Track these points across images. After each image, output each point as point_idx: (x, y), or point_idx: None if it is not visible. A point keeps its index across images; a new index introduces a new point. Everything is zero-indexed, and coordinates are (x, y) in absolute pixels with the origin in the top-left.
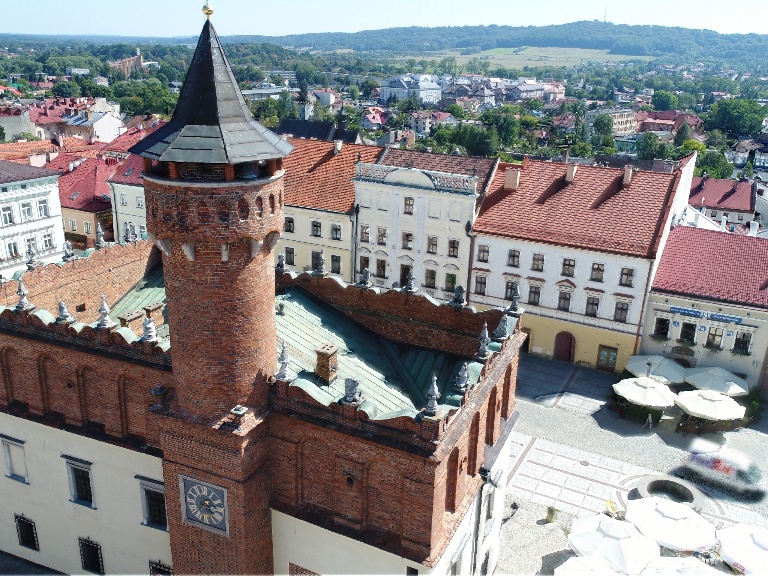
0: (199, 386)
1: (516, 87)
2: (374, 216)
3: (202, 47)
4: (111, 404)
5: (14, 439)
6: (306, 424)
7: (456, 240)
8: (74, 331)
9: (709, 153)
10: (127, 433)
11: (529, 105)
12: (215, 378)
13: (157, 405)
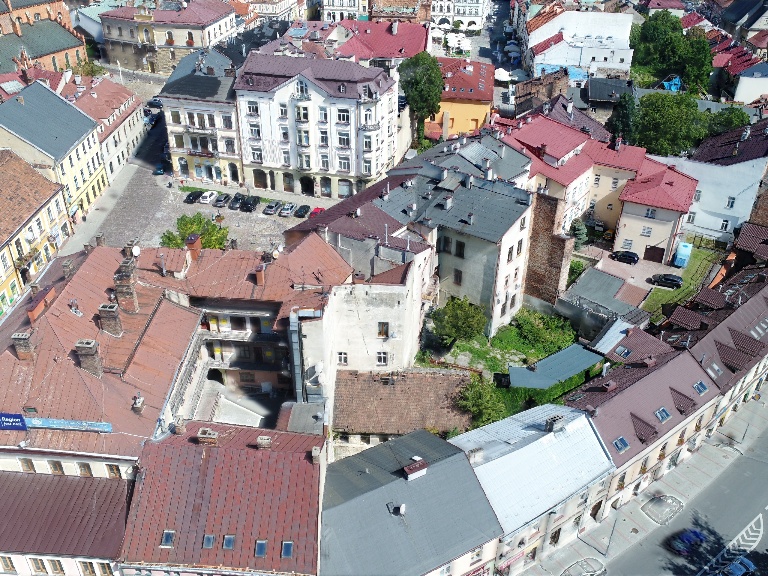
0: None
1: None
2: None
3: None
4: None
5: None
6: None
7: None
8: None
9: None
10: None
11: None
12: None
13: None
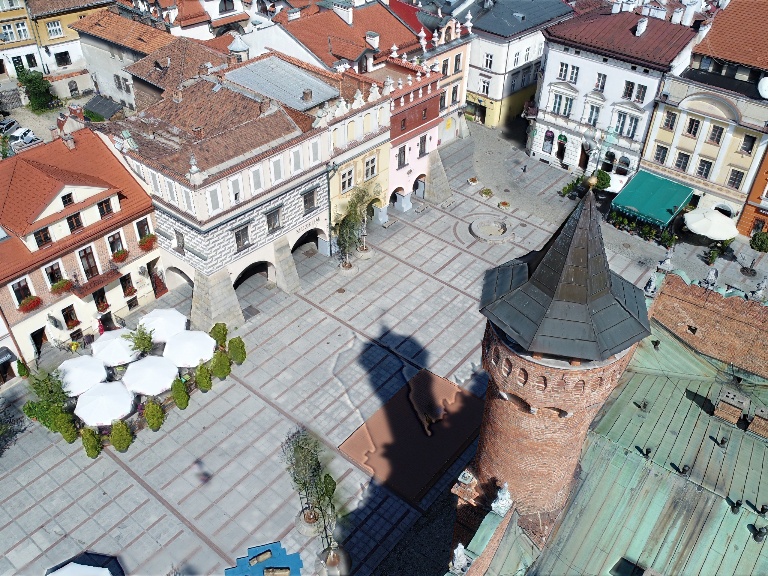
0: None
1: None
2: None
3: None
4: None
5: None
6: None
7: None
8: None
9: None
10: None
11: None
12: None
13: None
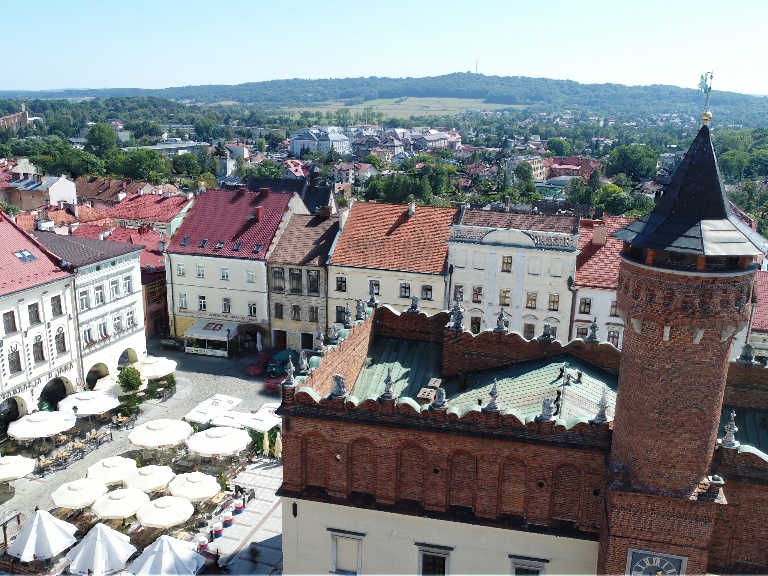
0: (676, 461)
1: (422, 137)
2: (469, 275)
3: (704, 149)
4: (487, 486)
5: (352, 532)
6: (753, 487)
7: (557, 294)
8: (453, 416)
9: (638, 196)
10: (500, 513)
11: (440, 154)
12: (694, 452)
13: (617, 483)
